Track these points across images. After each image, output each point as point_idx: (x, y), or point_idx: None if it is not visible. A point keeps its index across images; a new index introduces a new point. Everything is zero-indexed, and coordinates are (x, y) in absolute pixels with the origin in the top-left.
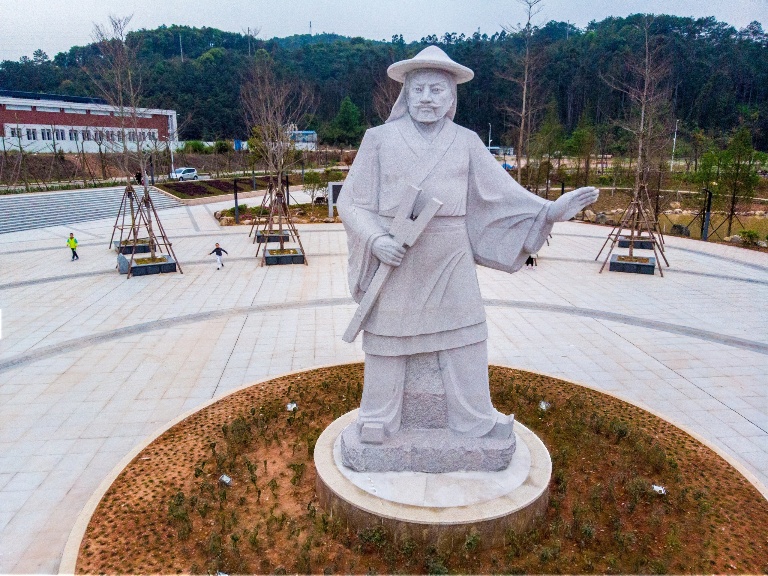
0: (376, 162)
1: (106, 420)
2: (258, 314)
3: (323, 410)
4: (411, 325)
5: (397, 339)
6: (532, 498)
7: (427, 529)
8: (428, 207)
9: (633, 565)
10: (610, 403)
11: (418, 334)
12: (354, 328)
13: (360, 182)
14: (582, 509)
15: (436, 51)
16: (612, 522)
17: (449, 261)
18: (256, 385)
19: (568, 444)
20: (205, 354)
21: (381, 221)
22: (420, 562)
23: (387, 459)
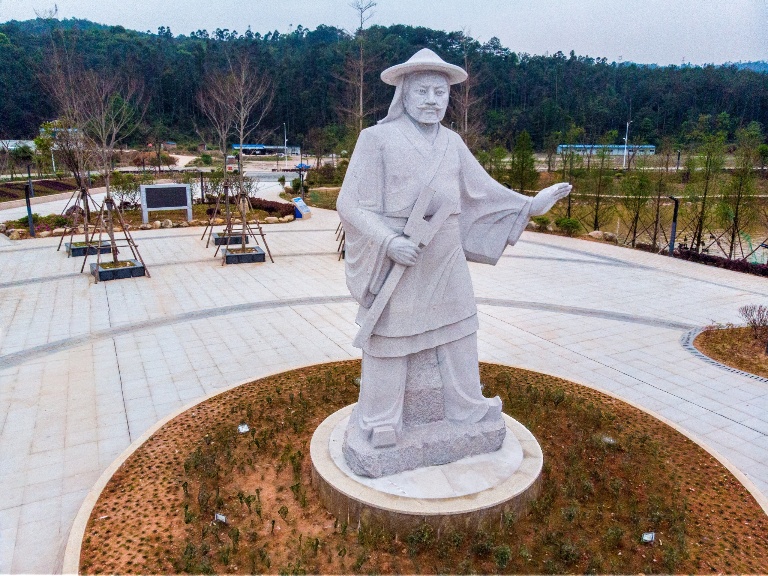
0: (380, 163)
1: (5, 485)
2: (126, 336)
3: (277, 426)
4: (418, 323)
5: (406, 339)
6: (540, 468)
7: (469, 517)
8: (445, 206)
9: (631, 506)
10: (528, 375)
11: (424, 331)
12: (366, 333)
13: (365, 184)
14: (574, 469)
15: (433, 54)
16: (593, 475)
17: (450, 258)
18: (184, 413)
19: (519, 417)
20: (88, 389)
21: (389, 222)
22: (474, 549)
23: (402, 459)
